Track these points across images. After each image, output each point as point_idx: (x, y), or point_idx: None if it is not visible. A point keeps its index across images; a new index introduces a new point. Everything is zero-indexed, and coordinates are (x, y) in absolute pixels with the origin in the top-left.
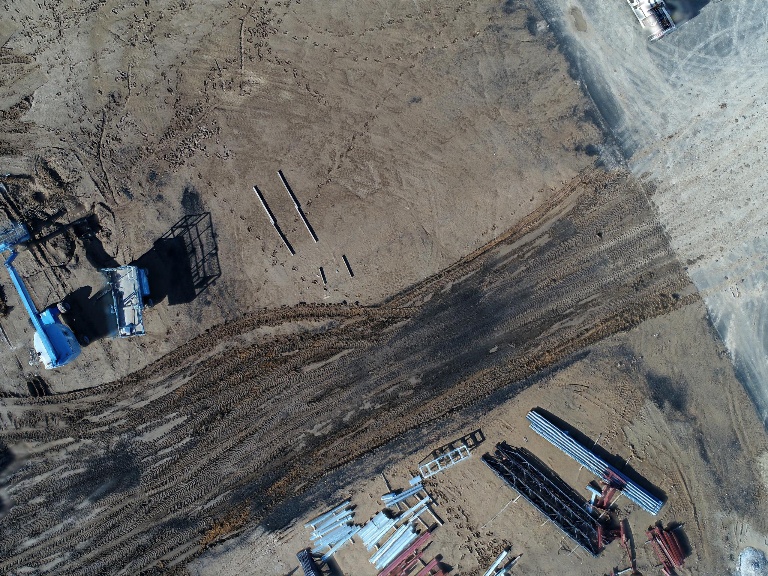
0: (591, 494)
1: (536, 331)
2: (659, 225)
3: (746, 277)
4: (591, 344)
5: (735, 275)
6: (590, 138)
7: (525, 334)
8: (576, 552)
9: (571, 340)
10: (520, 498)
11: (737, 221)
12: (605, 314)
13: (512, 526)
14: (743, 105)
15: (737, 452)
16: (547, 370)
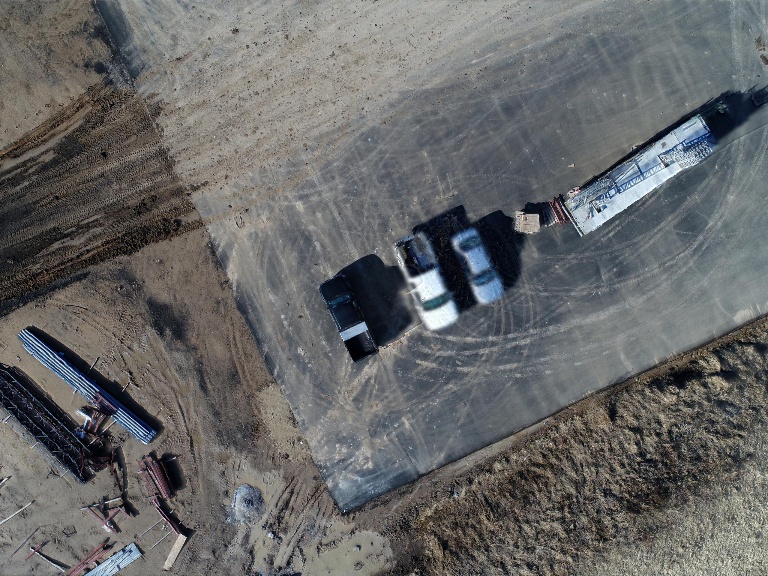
0: (85, 419)
1: (36, 248)
2: (163, 148)
3: (251, 207)
4: (91, 265)
5: (239, 204)
6: (99, 55)
7: (24, 251)
8: (66, 477)
9: (70, 260)
10: (11, 418)
11: (243, 149)
12: (107, 236)
13: (2, 447)
14: (255, 32)
15: (237, 386)
16: (44, 289)
